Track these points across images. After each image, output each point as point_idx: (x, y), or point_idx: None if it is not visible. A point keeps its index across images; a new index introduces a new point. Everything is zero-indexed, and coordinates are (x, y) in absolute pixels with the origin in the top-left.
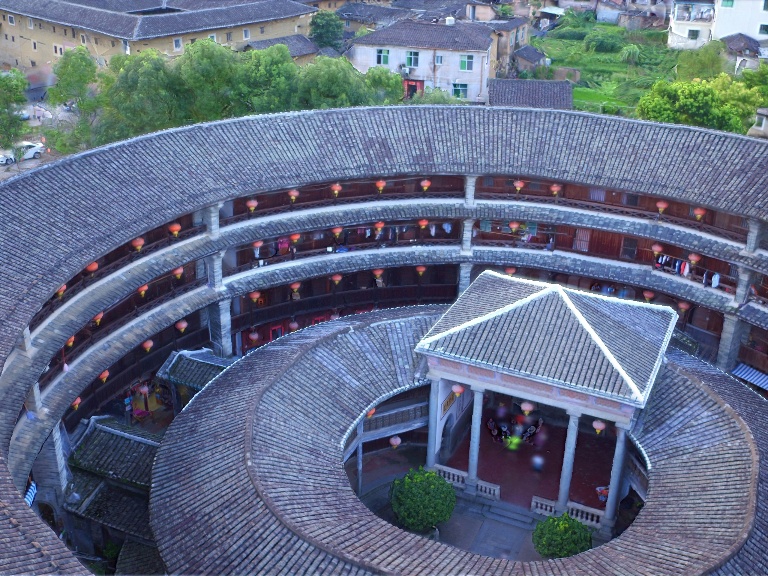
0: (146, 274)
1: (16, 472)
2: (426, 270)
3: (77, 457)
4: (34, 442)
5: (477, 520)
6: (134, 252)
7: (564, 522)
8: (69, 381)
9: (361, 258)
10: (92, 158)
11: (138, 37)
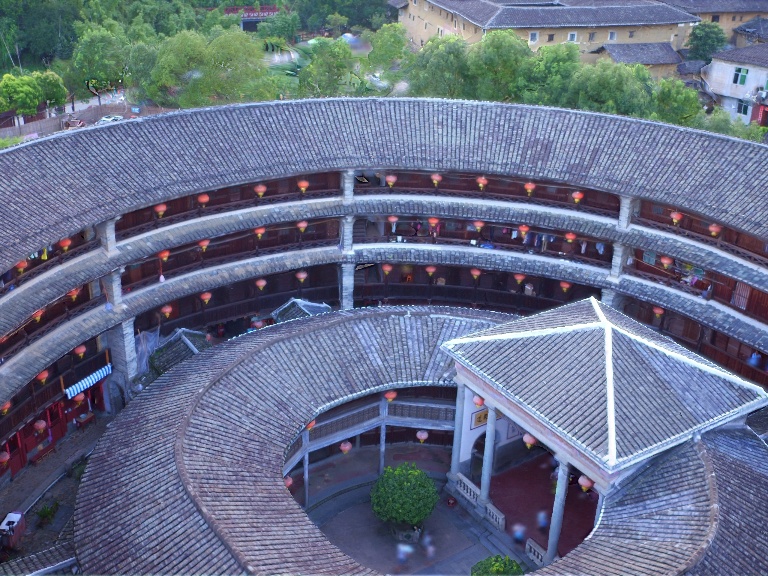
0: (263, 219)
1: (62, 343)
2: (570, 287)
3: (156, 356)
4: (95, 326)
5: (469, 541)
6: (261, 198)
7: (500, 565)
8: (162, 291)
9: (502, 258)
10: (255, 110)
11: (490, 26)
